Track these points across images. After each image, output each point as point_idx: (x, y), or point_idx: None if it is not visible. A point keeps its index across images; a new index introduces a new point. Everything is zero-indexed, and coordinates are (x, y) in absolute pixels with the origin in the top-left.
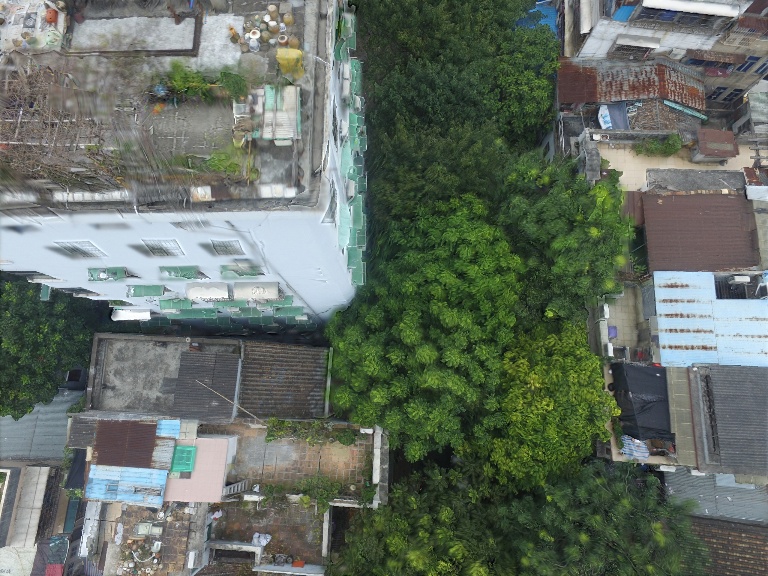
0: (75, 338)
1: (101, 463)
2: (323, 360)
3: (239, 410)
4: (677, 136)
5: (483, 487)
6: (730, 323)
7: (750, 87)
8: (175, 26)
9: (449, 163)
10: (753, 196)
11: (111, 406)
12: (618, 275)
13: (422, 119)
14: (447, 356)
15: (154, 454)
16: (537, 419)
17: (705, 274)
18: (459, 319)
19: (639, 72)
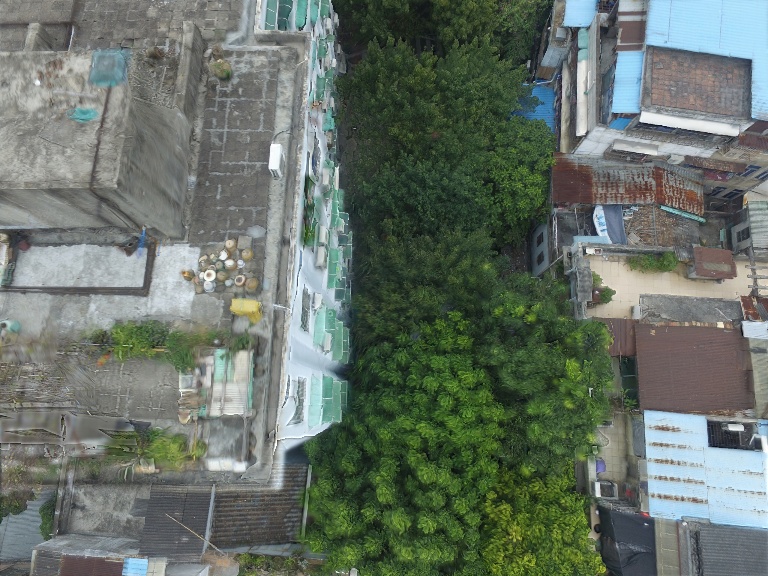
0: (43, 461)
1: None
2: (301, 478)
3: (211, 539)
4: (673, 254)
5: None
6: (722, 475)
7: (750, 189)
8: (126, 257)
9: (436, 277)
10: (749, 334)
11: (80, 528)
12: (608, 404)
13: (412, 215)
14: (424, 521)
15: None
16: (518, 573)
17: (697, 418)
18: (438, 474)
19: (636, 174)
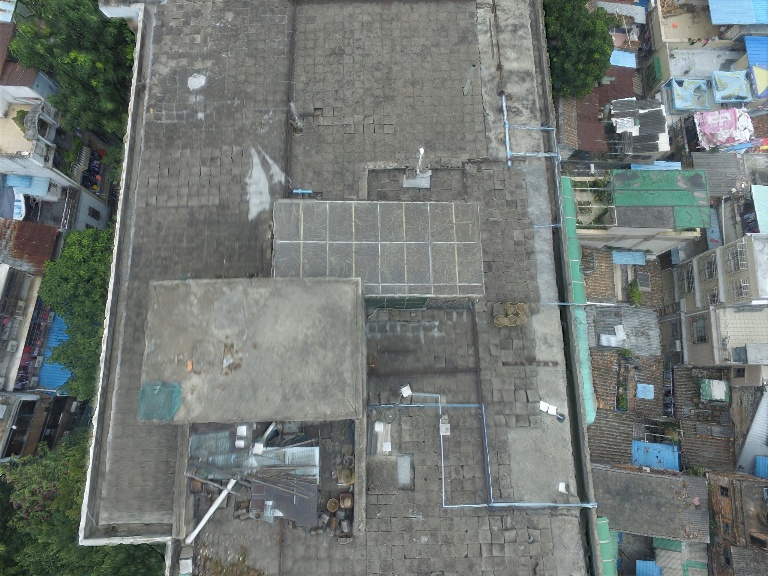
0: None
1: None
2: None
3: None
4: None
5: None
6: None
7: None
8: None
9: None
10: None
11: None
12: None
13: None
14: None
15: None
16: None
17: None
18: None
19: None
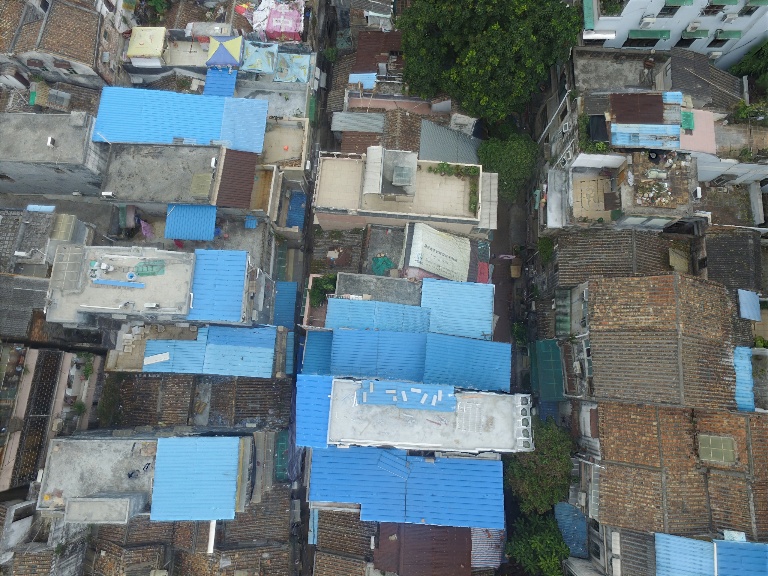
0: None
1: (620, 122)
2: (738, 86)
3: None
4: None
5: None
6: None
7: None
8: None
9: None
10: None
11: None
12: None
13: None
14: None
15: (665, 115)
16: None
17: None
18: None
19: None
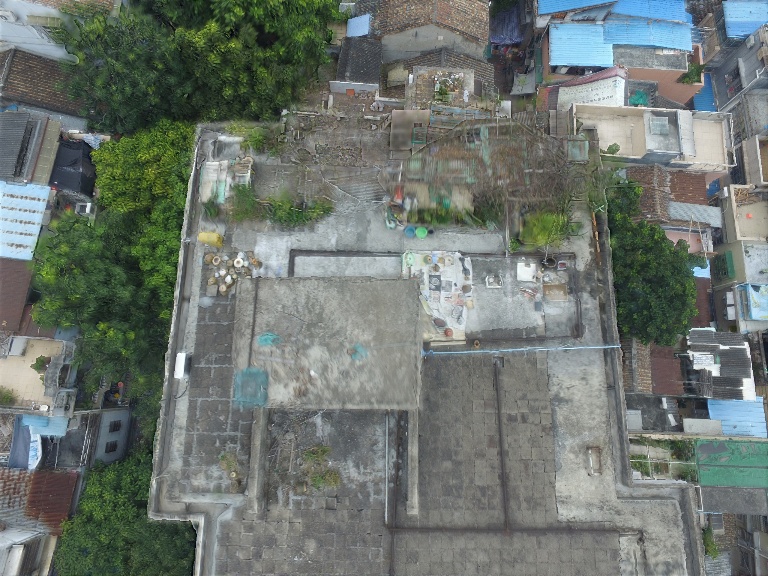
0: None
1: None
2: None
3: None
4: None
5: (207, 123)
6: None
7: None
8: None
9: None
10: None
11: None
12: None
13: None
14: None
15: None
16: None
17: None
18: None
19: None
